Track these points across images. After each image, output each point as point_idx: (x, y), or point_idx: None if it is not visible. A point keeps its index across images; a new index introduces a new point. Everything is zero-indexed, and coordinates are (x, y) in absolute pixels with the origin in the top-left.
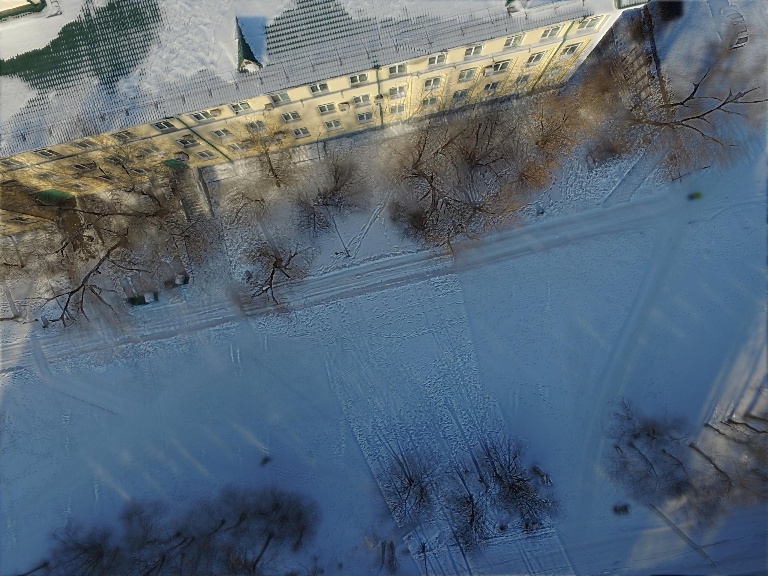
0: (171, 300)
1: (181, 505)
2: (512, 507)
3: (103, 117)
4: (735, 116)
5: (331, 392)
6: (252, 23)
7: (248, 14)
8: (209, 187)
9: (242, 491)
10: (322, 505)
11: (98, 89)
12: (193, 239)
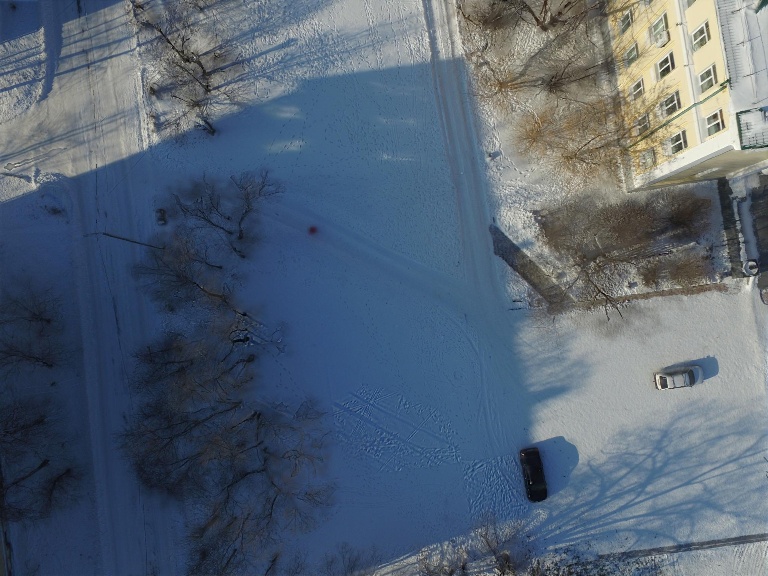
0: None
1: None
2: (174, 103)
3: None
4: (579, 375)
5: None
6: None
7: None
8: None
9: None
10: None
11: None
12: None
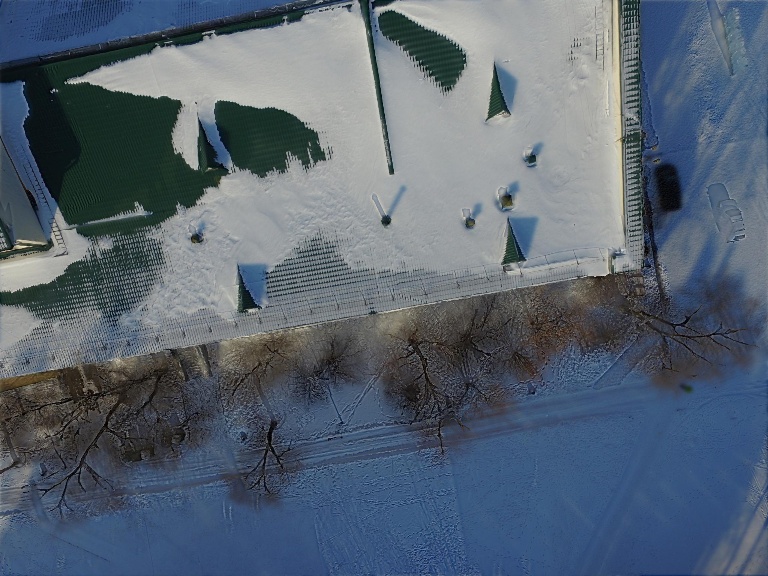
0: (167, 455)
1: None
2: None
3: (105, 346)
4: (728, 307)
5: (319, 554)
6: (253, 270)
7: (249, 262)
8: (208, 348)
9: None
10: None
11: (101, 321)
12: (191, 396)
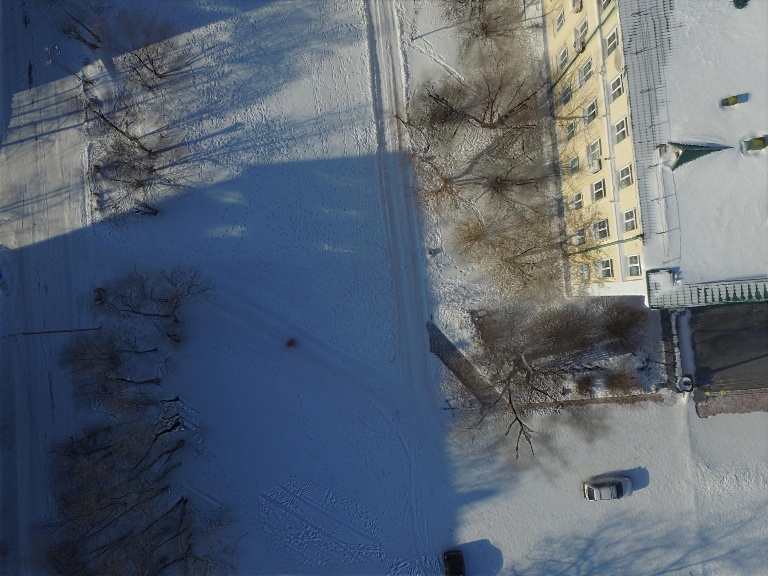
0: None
1: None
2: (118, 181)
3: None
4: (508, 478)
5: (267, 2)
6: None
7: None
8: None
9: None
10: None
11: None
12: None
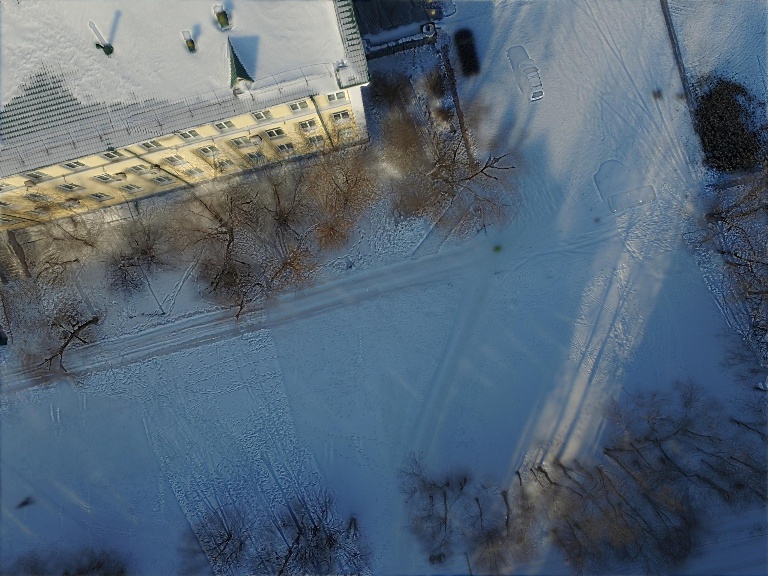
0: None
1: (4, 565)
2: None
3: None
4: (537, 167)
5: (149, 449)
6: None
7: None
8: (24, 248)
9: (64, 550)
10: (142, 562)
11: None
12: (11, 300)
